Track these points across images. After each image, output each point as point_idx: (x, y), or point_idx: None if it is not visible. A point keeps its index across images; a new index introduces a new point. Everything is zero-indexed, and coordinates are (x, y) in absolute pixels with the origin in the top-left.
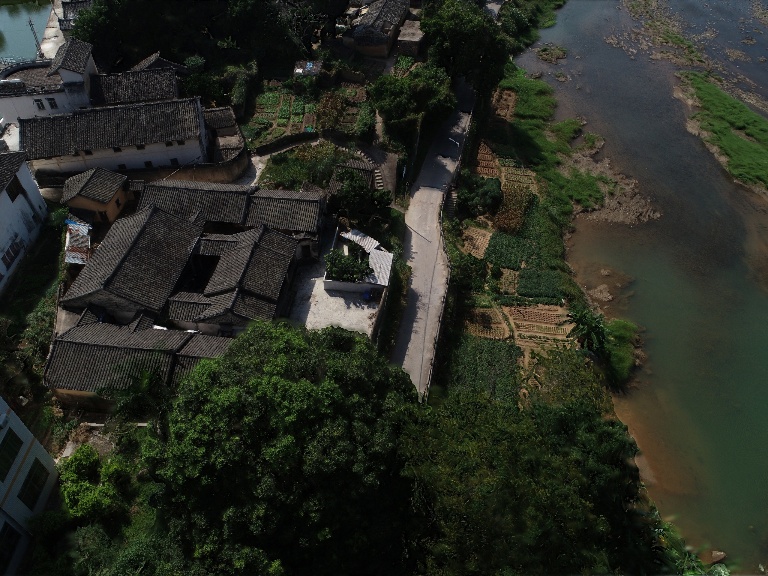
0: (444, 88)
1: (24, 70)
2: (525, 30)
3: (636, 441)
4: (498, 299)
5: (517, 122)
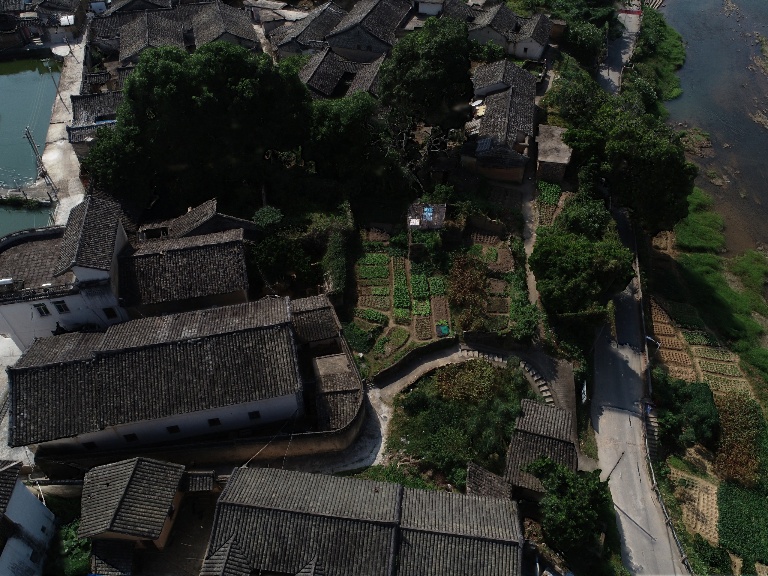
0: (620, 244)
1: (18, 245)
2: (651, 105)
3: None
4: None
5: (685, 260)
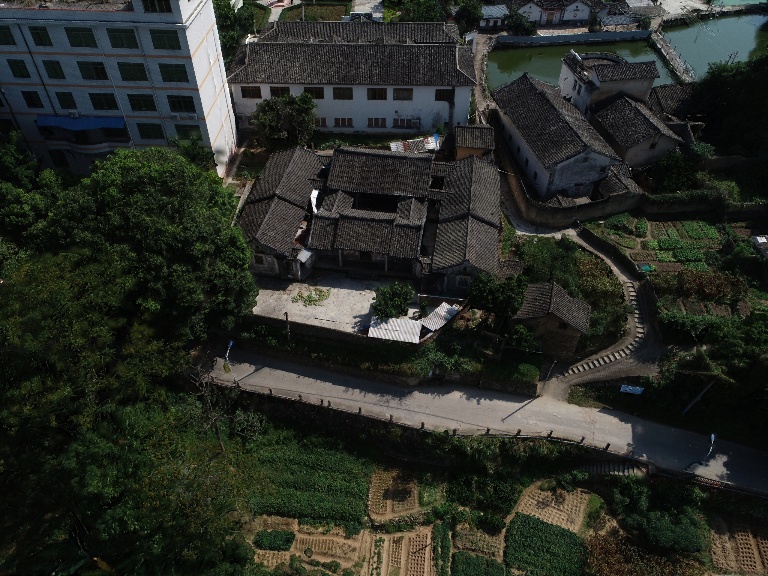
0: None
1: None
2: None
3: None
4: (443, 522)
5: None
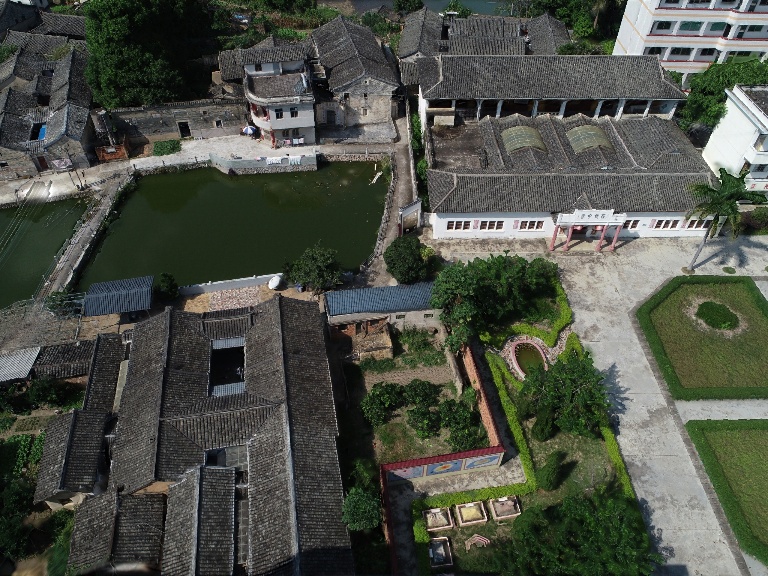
0: None
1: None
2: None
3: None
4: None
5: None
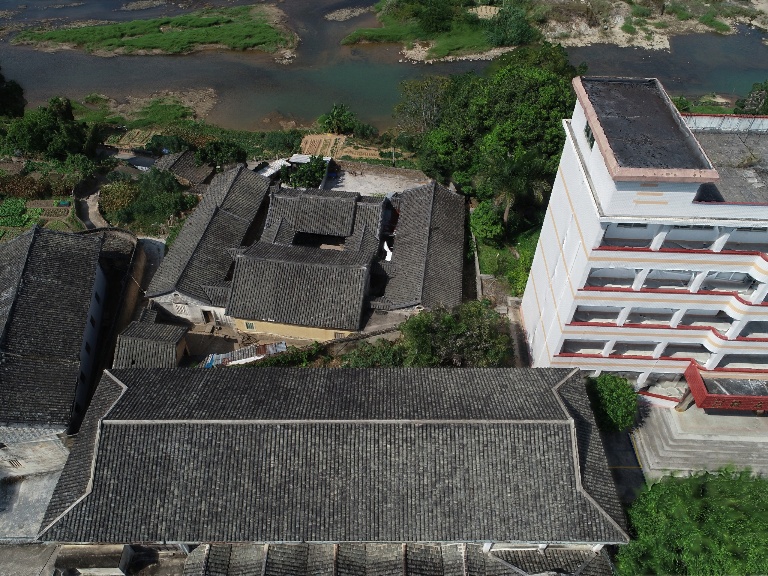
0: None
1: None
2: None
3: None
4: None
5: None
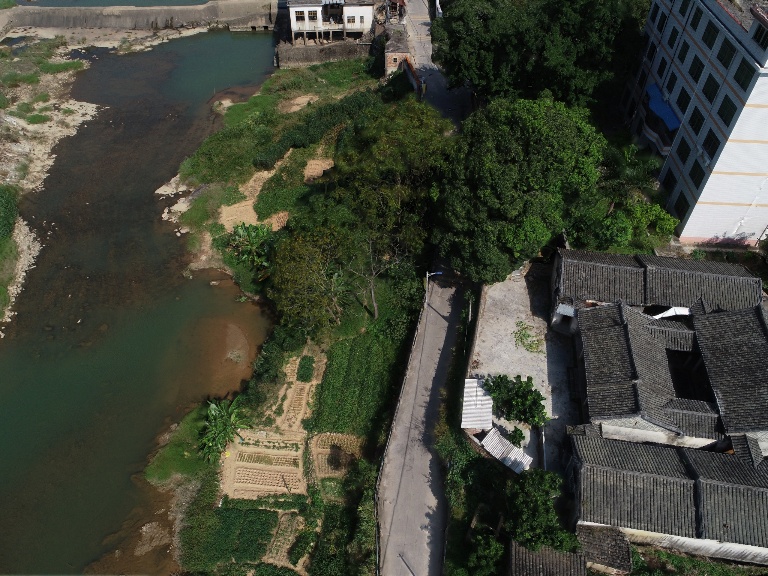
0: None
1: None
2: None
3: (226, 353)
4: None
5: None
